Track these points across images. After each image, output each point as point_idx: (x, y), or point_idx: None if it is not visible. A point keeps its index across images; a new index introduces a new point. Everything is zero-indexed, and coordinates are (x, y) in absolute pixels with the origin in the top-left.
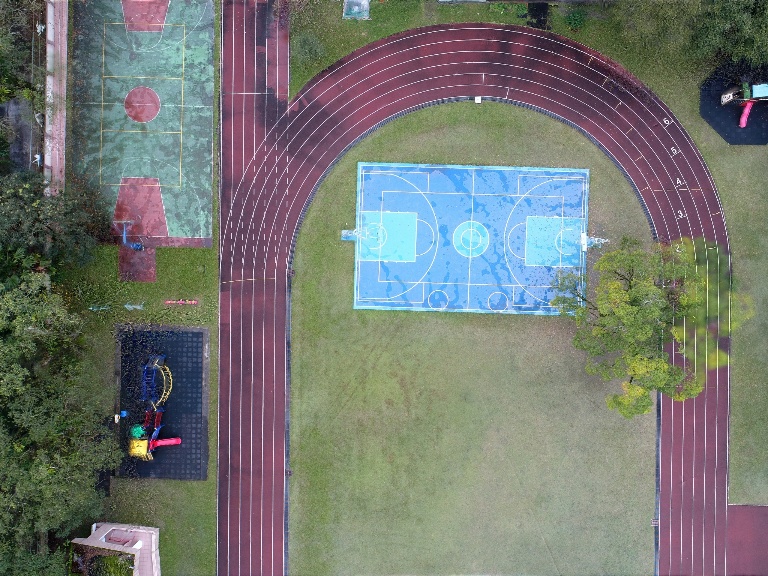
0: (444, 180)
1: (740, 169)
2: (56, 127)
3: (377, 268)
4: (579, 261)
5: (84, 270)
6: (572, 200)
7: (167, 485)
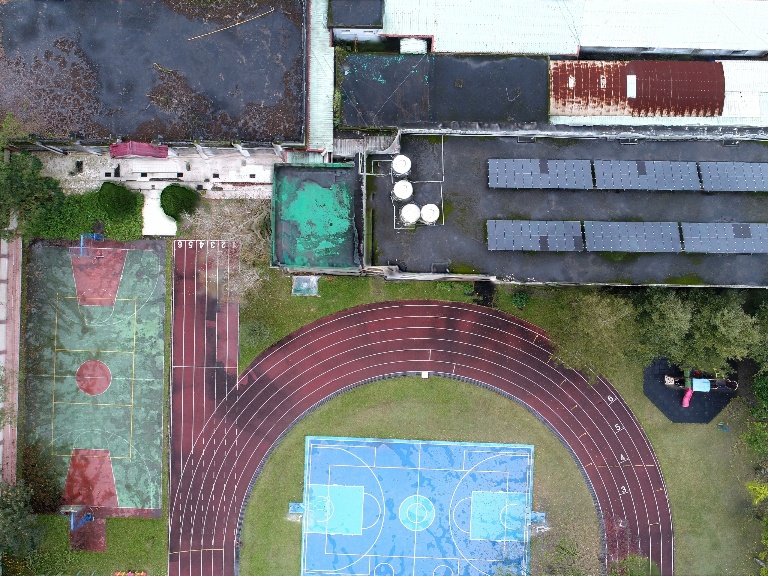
0: (391, 454)
1: (683, 446)
2: (8, 402)
3: (324, 540)
4: (523, 535)
5: (35, 539)
6: (517, 475)
7: None
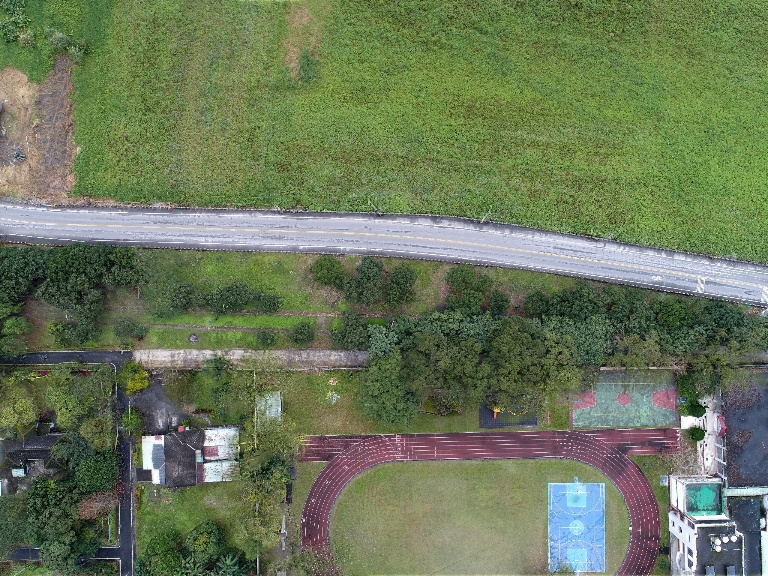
0: (599, 516)
1: None
2: None
3: (564, 492)
4: (570, 570)
5: None
6: (593, 566)
7: (477, 413)
